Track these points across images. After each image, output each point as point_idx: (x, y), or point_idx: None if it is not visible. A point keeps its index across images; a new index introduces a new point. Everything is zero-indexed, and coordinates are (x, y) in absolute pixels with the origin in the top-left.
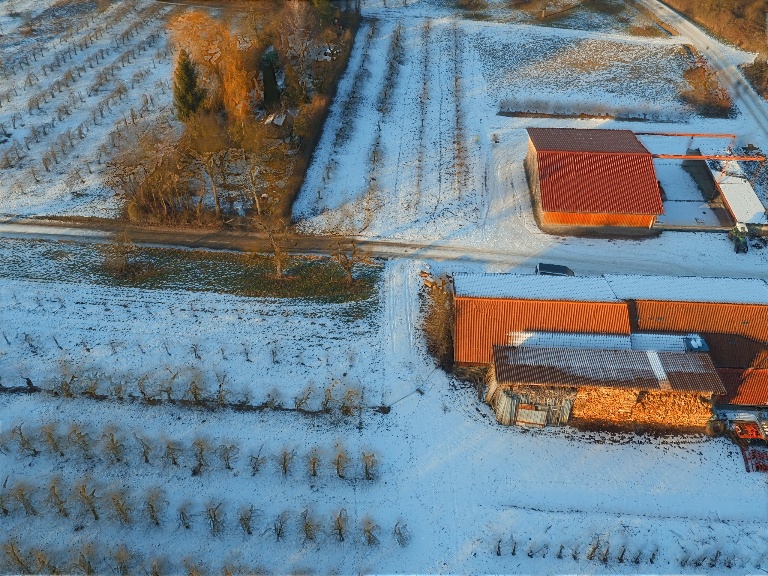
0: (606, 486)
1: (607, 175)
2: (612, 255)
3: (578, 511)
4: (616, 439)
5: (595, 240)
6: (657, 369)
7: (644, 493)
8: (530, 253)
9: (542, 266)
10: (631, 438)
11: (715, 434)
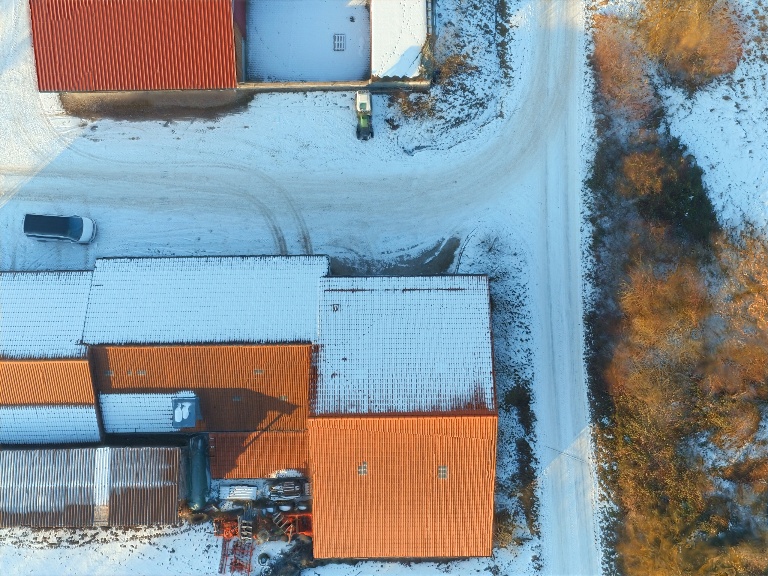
0: None
1: (147, 0)
2: (164, 159)
3: None
4: (74, 540)
5: (144, 125)
6: (99, 485)
7: None
8: (35, 167)
9: (29, 222)
10: (94, 536)
11: (196, 522)
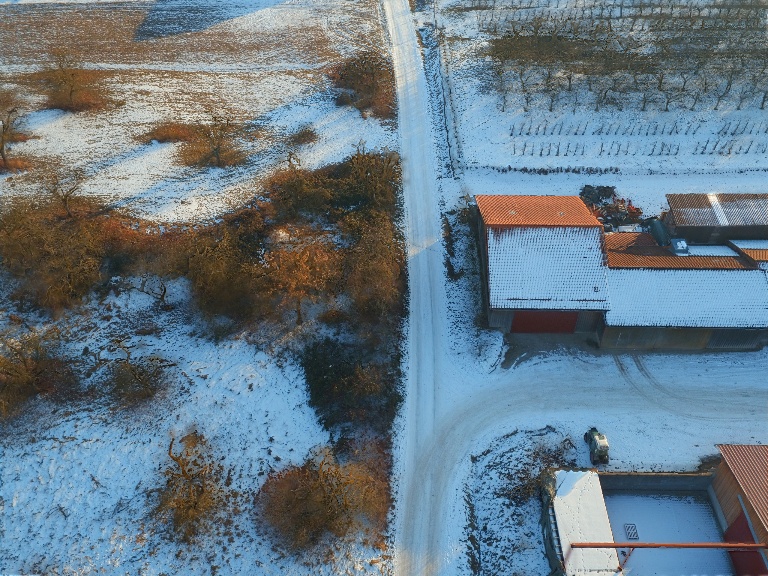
0: (725, 187)
1: None
2: (759, 423)
3: (741, 172)
4: None
5: None
6: (719, 209)
7: (699, 186)
8: None
9: None
10: None
11: None
